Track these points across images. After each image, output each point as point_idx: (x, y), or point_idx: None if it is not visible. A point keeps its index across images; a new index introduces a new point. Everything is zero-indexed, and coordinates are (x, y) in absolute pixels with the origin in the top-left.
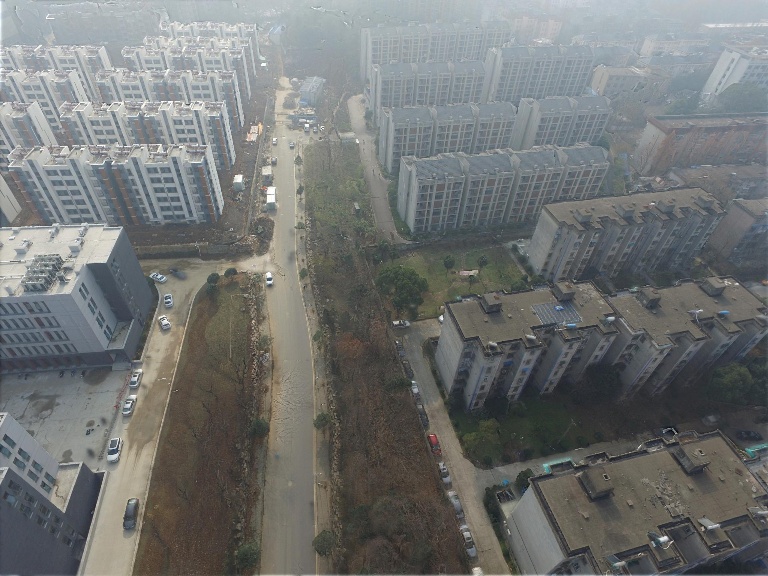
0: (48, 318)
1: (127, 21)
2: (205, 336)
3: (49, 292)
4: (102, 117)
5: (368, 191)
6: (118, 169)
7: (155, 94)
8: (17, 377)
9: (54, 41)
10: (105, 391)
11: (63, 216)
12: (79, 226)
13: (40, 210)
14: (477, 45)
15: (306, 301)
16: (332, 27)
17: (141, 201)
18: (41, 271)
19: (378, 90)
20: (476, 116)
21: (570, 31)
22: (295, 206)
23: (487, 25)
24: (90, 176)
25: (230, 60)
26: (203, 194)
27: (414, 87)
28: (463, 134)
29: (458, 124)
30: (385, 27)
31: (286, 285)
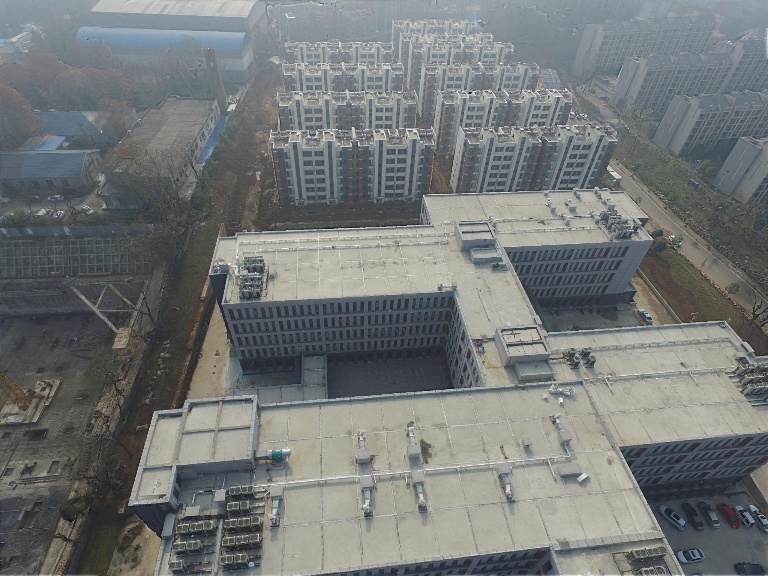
0: (614, 262)
1: (352, 19)
2: (678, 284)
3: (634, 239)
4: (479, 103)
5: (683, 170)
6: (551, 146)
7: (471, 84)
8: (549, 314)
9: (287, 38)
10: (628, 325)
11: (484, 188)
12: (588, 190)
13: (467, 182)
14: (684, 39)
15: (721, 259)
16: (542, 23)
17: (547, 175)
18: (618, 223)
19: (637, 80)
20: (765, 102)
21: (740, 25)
22: (633, 182)
23: (697, 20)
24: (525, 152)
25: (504, 54)
26: (601, 169)
27: (671, 77)
28: (750, 119)
29: (751, 110)
30: (613, 22)
31: (691, 246)
